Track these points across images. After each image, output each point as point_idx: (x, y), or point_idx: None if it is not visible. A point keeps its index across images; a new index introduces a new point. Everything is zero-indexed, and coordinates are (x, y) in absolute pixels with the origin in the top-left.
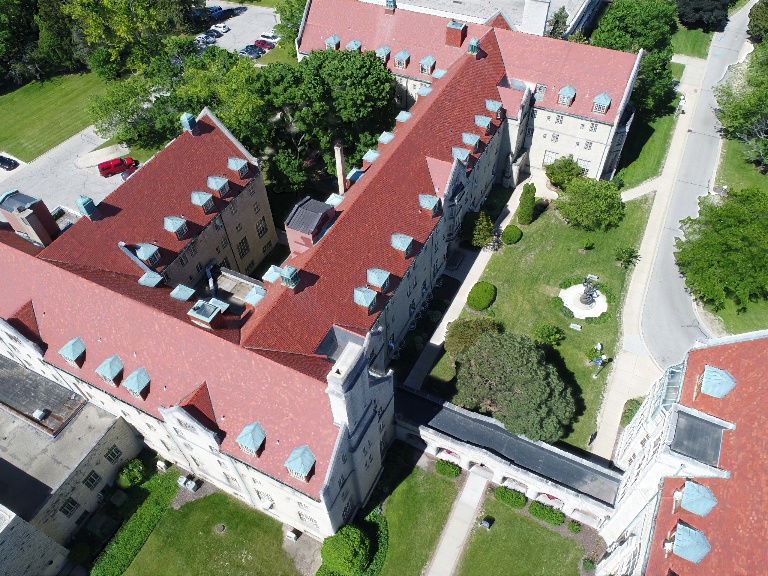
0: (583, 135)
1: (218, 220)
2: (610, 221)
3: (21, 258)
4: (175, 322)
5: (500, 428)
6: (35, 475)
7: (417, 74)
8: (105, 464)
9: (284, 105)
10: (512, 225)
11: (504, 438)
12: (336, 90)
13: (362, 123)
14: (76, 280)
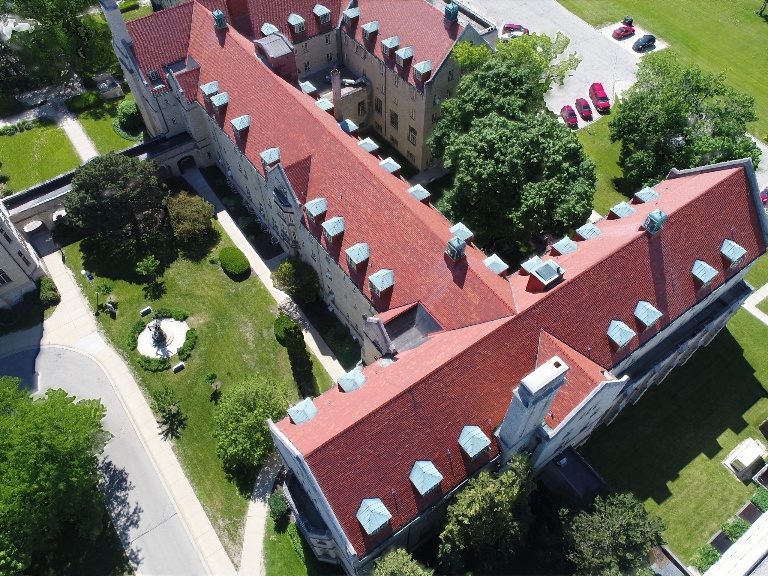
0: None
1: None
2: None
3: None
4: None
5: None
6: None
7: None
8: None
9: None
10: None
11: None
12: None
13: None
14: None
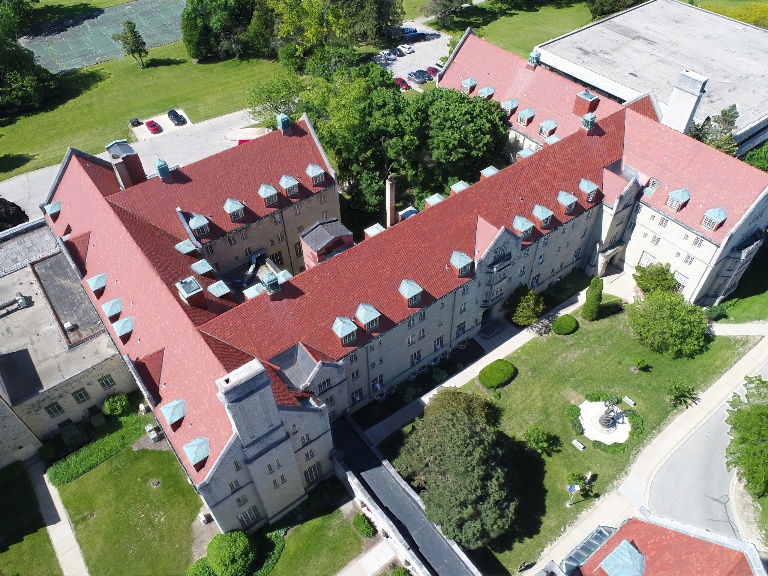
0: (685, 247)
1: (278, 216)
2: (681, 349)
3: (96, 195)
4: (163, 288)
5: (422, 509)
6: (40, 373)
7: (535, 135)
8: (97, 387)
9: (379, 130)
10: (570, 315)
11: (423, 521)
12: (435, 129)
13: (453, 167)
14: (120, 226)
